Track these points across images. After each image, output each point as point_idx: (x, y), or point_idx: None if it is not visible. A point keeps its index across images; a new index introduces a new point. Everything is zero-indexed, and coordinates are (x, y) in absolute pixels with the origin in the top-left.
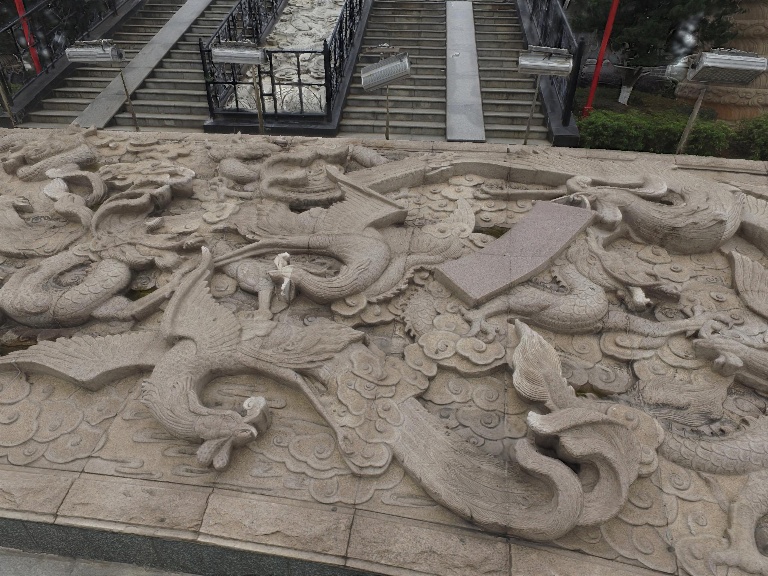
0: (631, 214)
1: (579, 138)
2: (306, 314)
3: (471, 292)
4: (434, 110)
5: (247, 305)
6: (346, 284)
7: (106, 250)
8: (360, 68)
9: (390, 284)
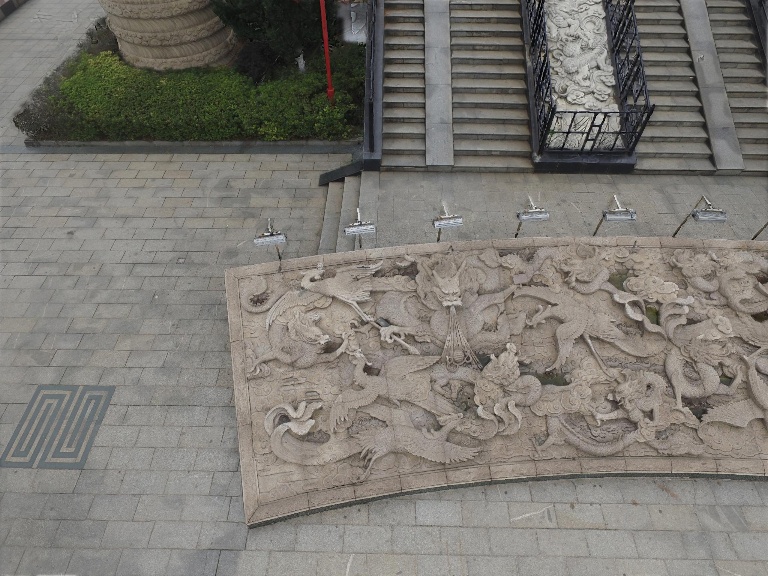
0: None
1: None
2: None
3: None
4: (695, 130)
5: (767, 381)
6: None
7: (698, 358)
8: None
9: None
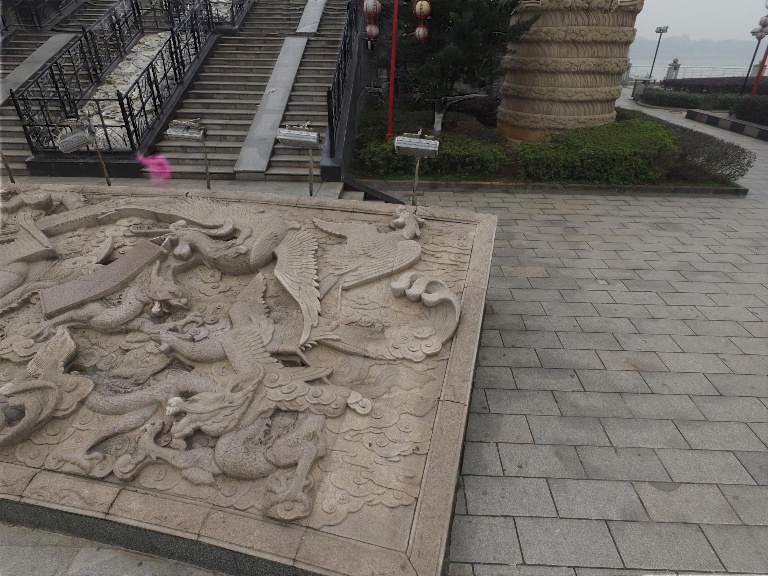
0: (198, 248)
1: (341, 168)
2: None
3: (47, 308)
4: (237, 143)
5: None
6: None
7: None
8: (186, 104)
9: (4, 304)
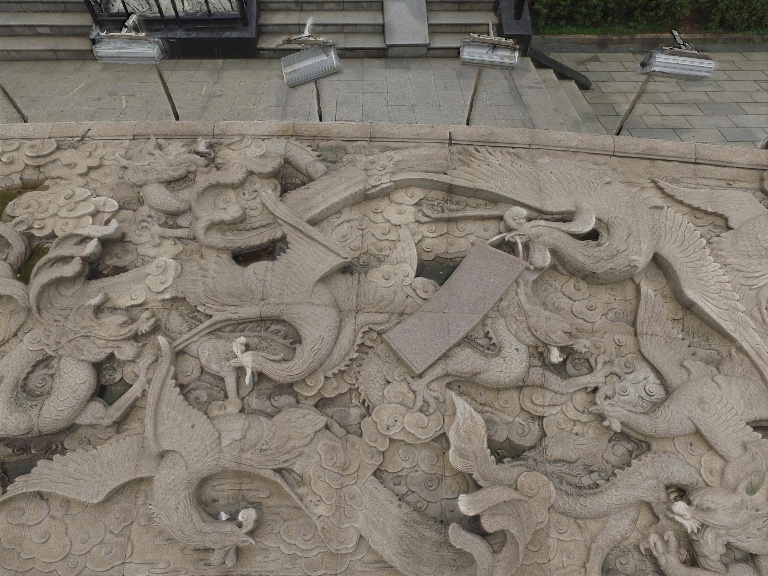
0: (559, 254)
1: None
2: (271, 393)
3: (415, 365)
4: None
5: (216, 388)
6: (304, 370)
7: (61, 347)
8: None
9: (343, 356)
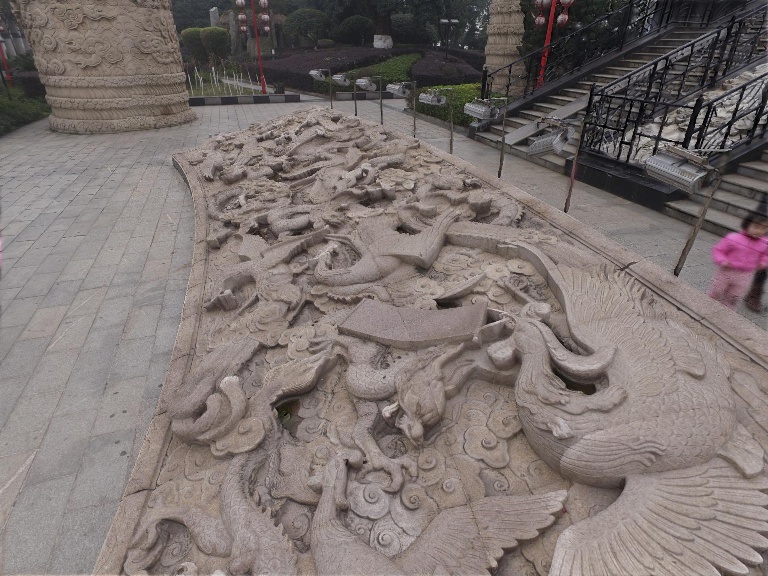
0: None
1: None
2: (312, 282)
3: (345, 321)
4: None
5: None
6: (323, 275)
7: None
8: None
9: (344, 292)
